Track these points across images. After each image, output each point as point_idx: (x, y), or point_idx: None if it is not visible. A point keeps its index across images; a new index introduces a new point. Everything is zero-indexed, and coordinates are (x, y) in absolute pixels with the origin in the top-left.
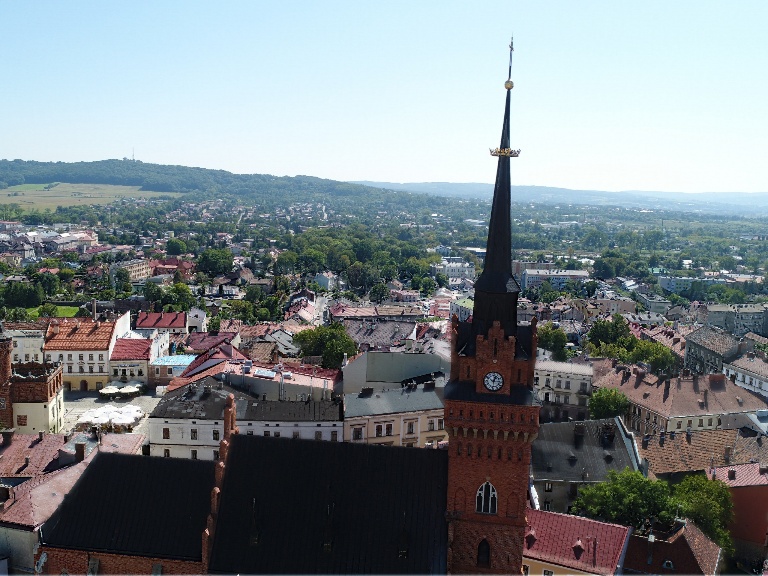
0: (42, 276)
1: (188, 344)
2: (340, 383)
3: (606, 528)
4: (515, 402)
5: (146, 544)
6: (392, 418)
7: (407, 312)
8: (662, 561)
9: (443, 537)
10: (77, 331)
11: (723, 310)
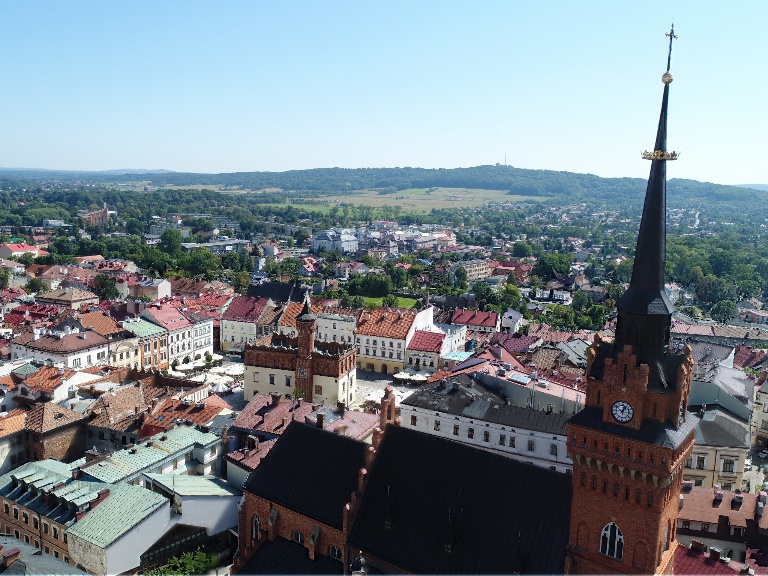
0: (393, 270)
1: None
2: None
3: None
4: (643, 439)
5: (311, 506)
6: None
7: (752, 335)
8: None
9: (561, 570)
10: (384, 320)
11: None
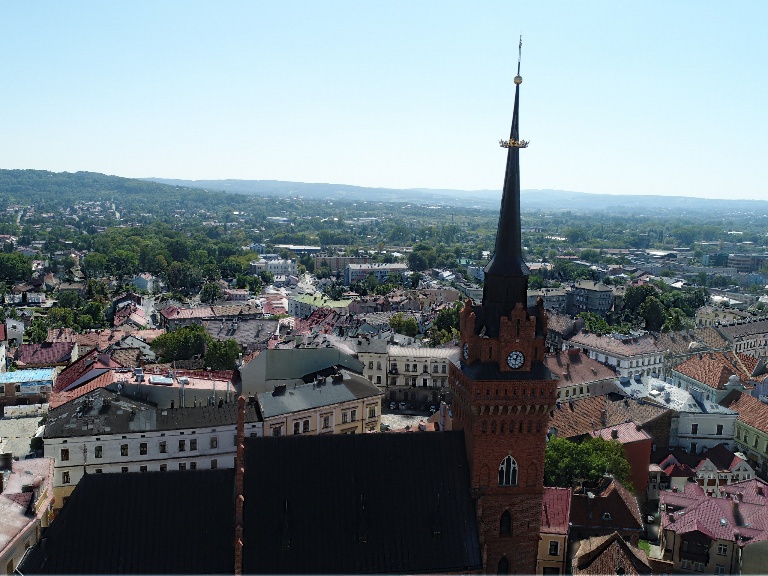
0: None
1: (17, 358)
2: (238, 384)
3: (552, 491)
4: (537, 377)
5: (160, 567)
6: (309, 414)
7: (245, 311)
8: (601, 514)
9: (471, 514)
10: None
11: (535, 294)
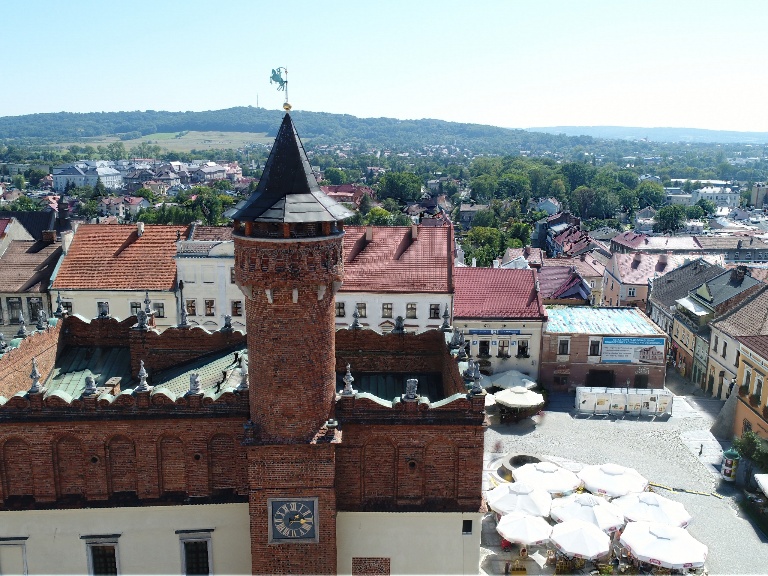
0: (201, 198)
1: None
2: None
3: None
4: None
5: None
6: None
7: (745, 244)
8: None
9: None
10: (367, 247)
11: None
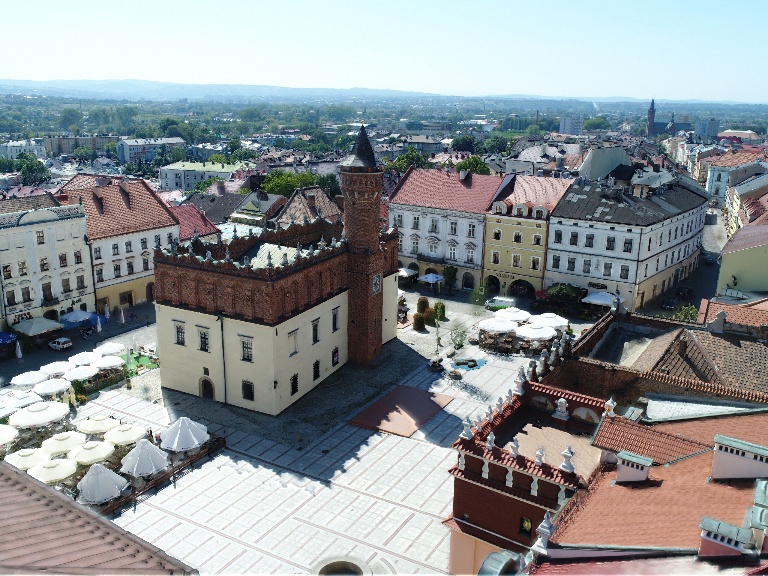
0: None
1: None
2: None
3: None
4: None
5: None
6: None
7: None
8: None
9: None
10: (104, 202)
11: (383, 150)
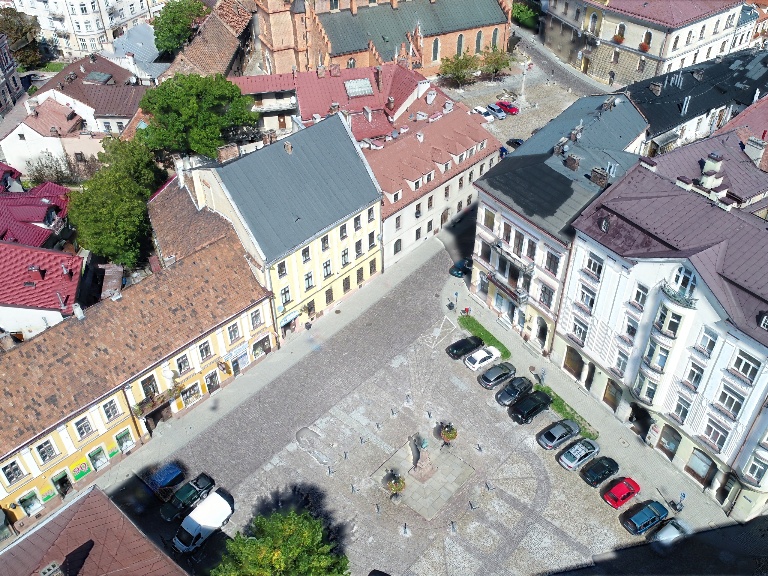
0: None
1: None
2: None
3: None
4: None
5: None
6: None
7: None
8: None
9: None
10: None
11: None
